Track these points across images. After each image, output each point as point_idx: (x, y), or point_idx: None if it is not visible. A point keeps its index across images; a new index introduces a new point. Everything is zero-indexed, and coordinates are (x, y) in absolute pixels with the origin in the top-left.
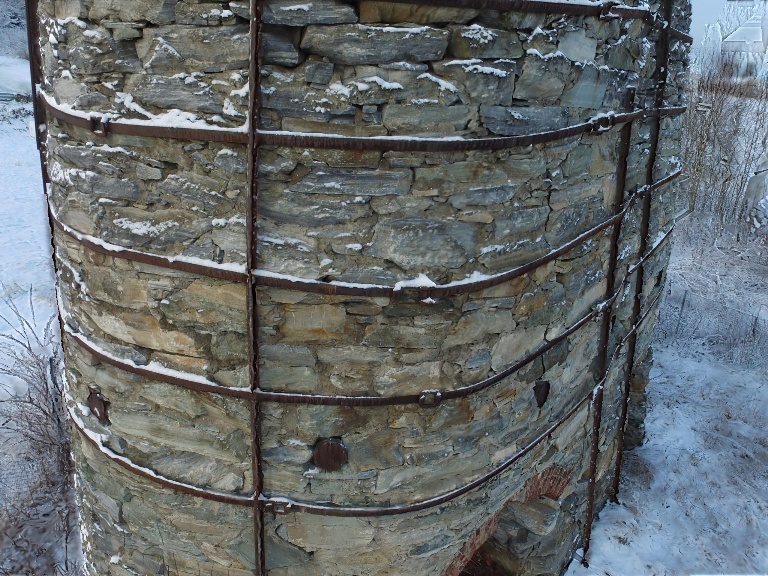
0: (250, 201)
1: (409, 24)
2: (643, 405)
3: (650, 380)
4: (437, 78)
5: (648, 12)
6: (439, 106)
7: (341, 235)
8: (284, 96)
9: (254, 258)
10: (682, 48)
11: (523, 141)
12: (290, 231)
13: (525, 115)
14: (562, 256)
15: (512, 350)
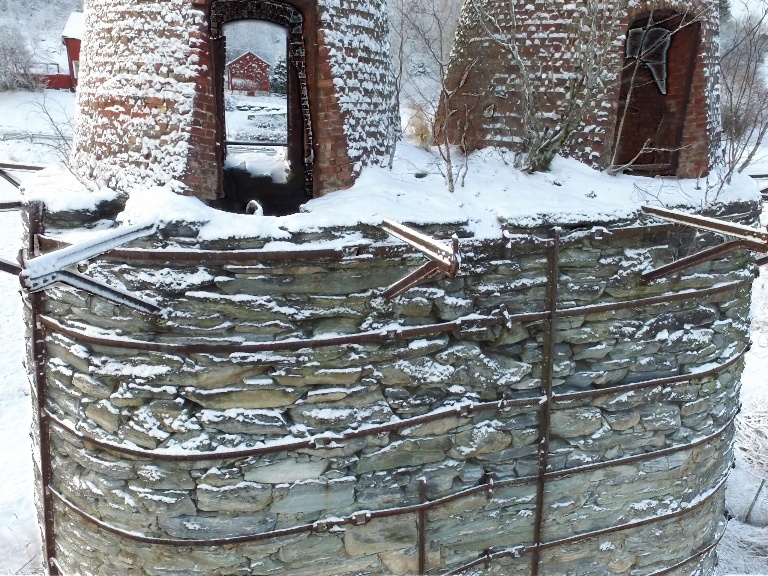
0: (45, 523)
1: (108, 457)
2: None
3: None
4: (126, 493)
5: (468, 407)
6: (125, 512)
7: (83, 564)
8: (59, 472)
9: (53, 552)
10: (655, 391)
11: (203, 543)
12: (68, 545)
13: (206, 525)
14: None
15: None
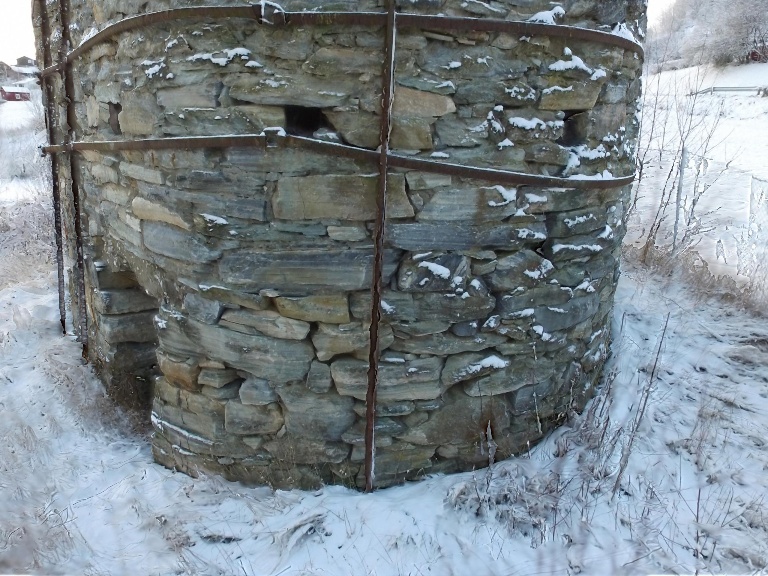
0: None
1: None
2: None
3: None
4: None
5: None
6: None
7: None
8: None
9: None
10: None
11: None
12: None
13: None
14: None
15: None
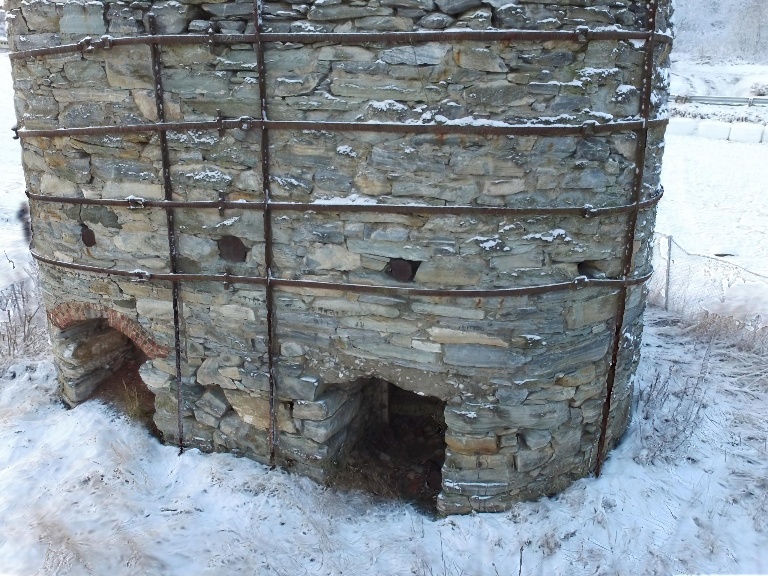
0: None
1: None
2: (444, 467)
3: (636, 532)
4: None
5: None
6: None
7: None
8: None
9: None
10: None
11: (28, 54)
12: None
13: None
14: (73, 136)
15: (51, 186)
